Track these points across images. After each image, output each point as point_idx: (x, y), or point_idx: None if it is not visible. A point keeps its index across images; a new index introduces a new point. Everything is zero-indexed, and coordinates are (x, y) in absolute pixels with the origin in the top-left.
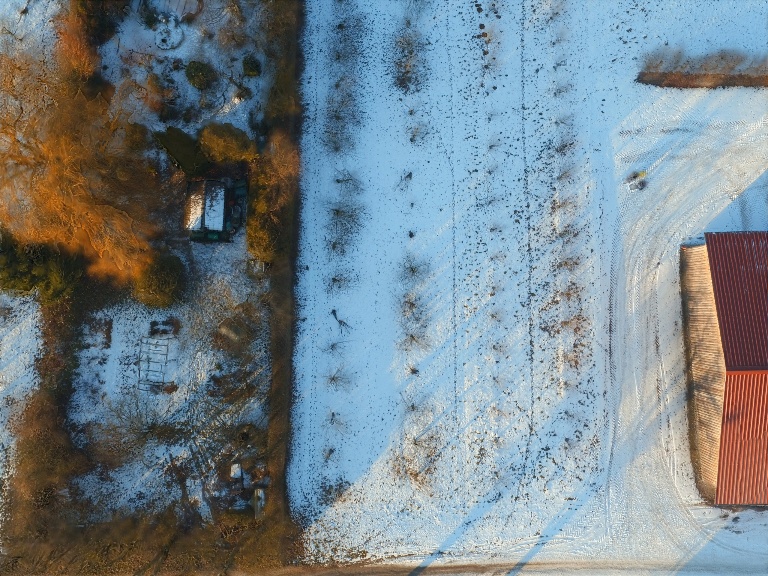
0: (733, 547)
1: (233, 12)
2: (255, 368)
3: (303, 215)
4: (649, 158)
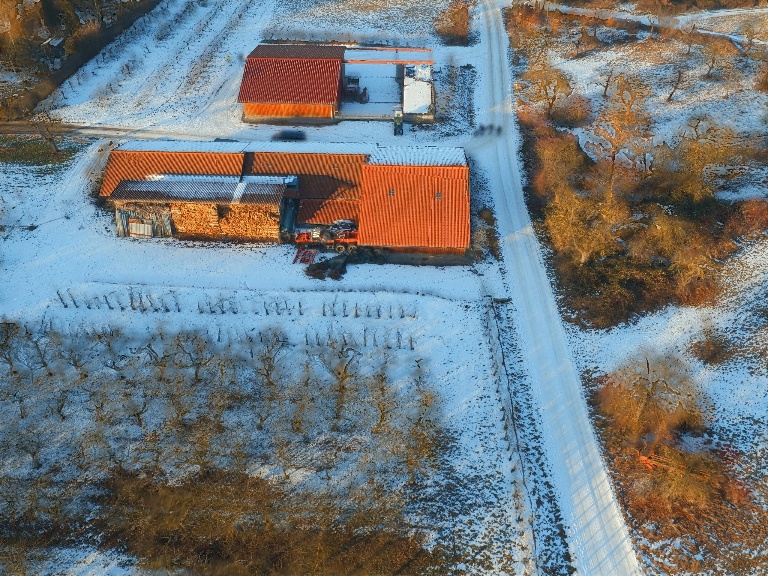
0: (252, 133)
1: (99, 23)
2: None
3: (96, 56)
4: None
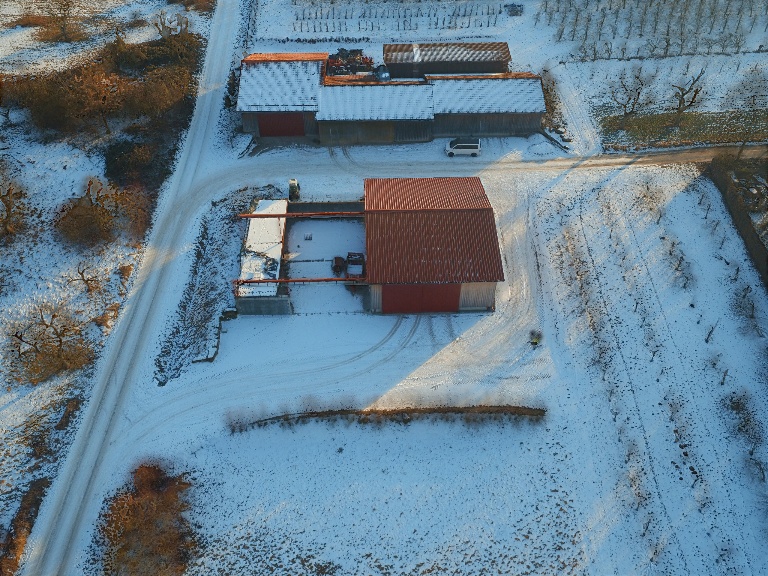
0: None
1: None
2: (765, 236)
3: None
4: (525, 361)
